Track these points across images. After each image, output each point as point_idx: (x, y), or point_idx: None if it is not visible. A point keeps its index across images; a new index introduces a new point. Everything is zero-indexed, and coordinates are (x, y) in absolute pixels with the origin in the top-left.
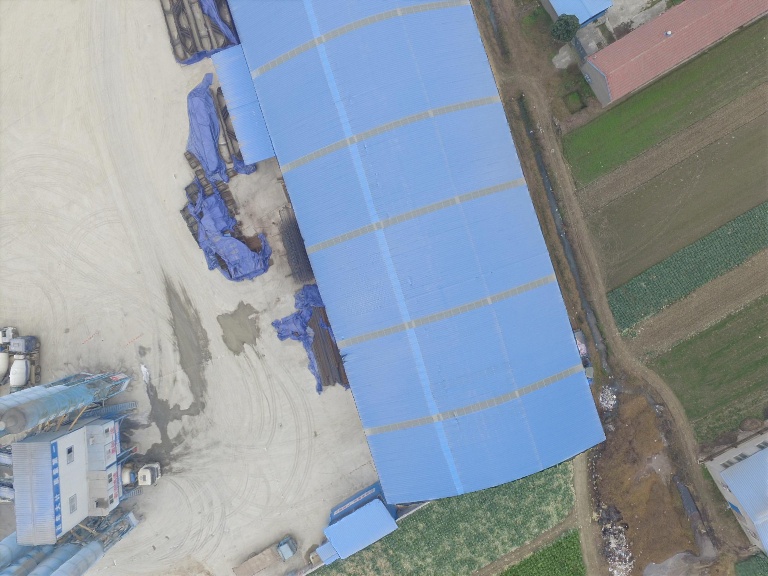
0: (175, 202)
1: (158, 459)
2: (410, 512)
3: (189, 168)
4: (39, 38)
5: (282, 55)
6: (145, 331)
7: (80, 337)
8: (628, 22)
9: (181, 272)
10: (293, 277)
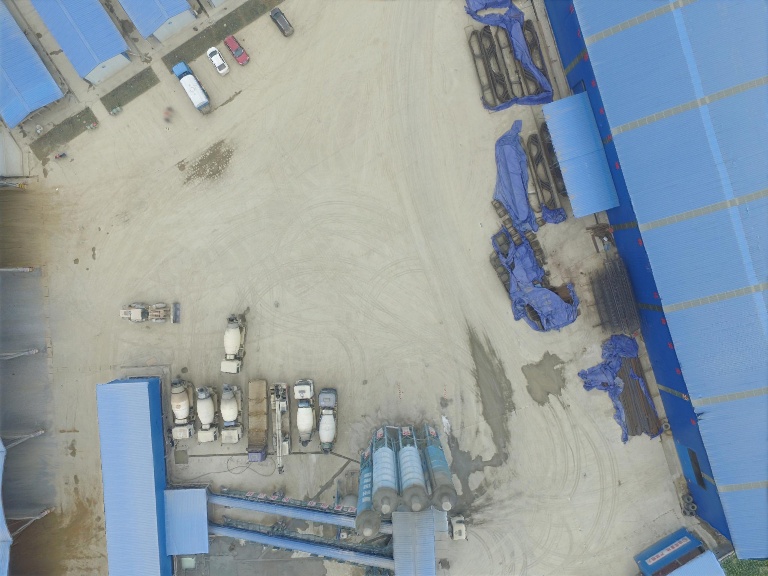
0: (480, 251)
1: (459, 511)
2: (720, 559)
3: (496, 217)
4: (339, 80)
5: (655, 114)
6: (447, 382)
7: (379, 389)
8: None
9: (485, 322)
10: (602, 328)
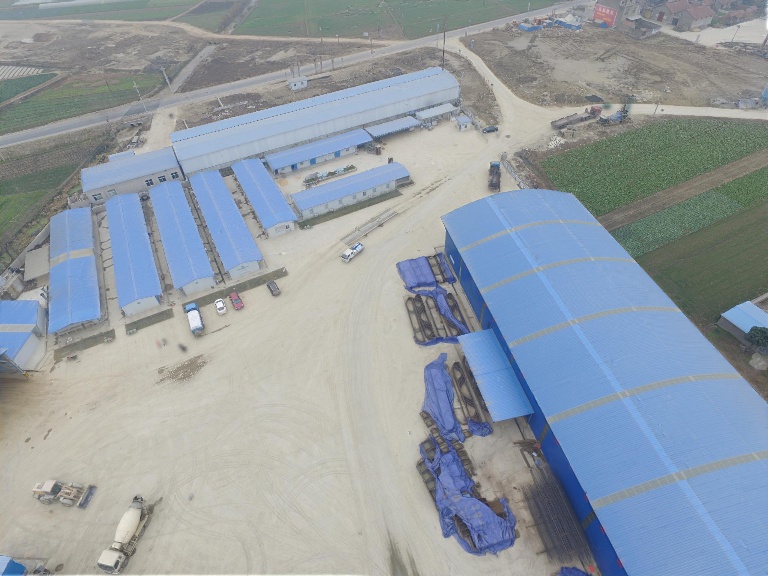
0: (408, 457)
1: None
2: None
3: (424, 426)
4: (305, 322)
5: (539, 331)
6: None
7: None
8: None
9: (410, 537)
10: (547, 555)
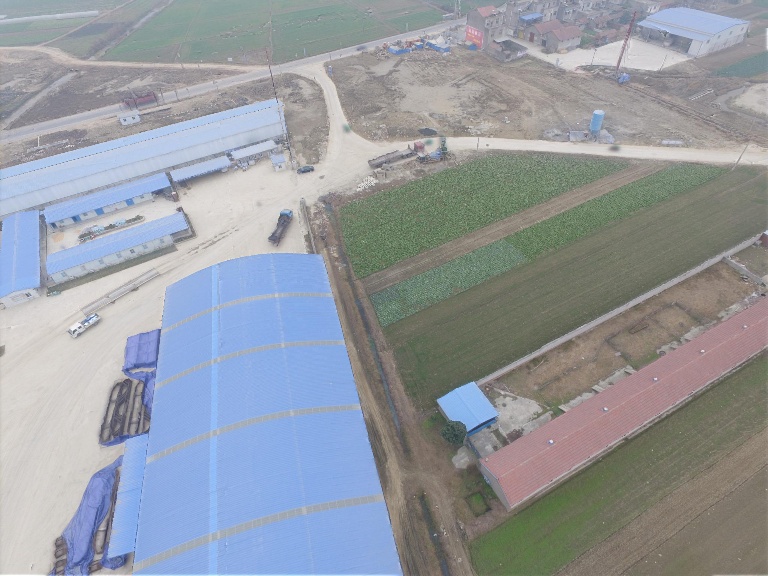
0: None
1: None
2: None
3: (53, 557)
4: None
5: (179, 444)
6: None
7: None
8: (519, 429)
9: None
10: None
